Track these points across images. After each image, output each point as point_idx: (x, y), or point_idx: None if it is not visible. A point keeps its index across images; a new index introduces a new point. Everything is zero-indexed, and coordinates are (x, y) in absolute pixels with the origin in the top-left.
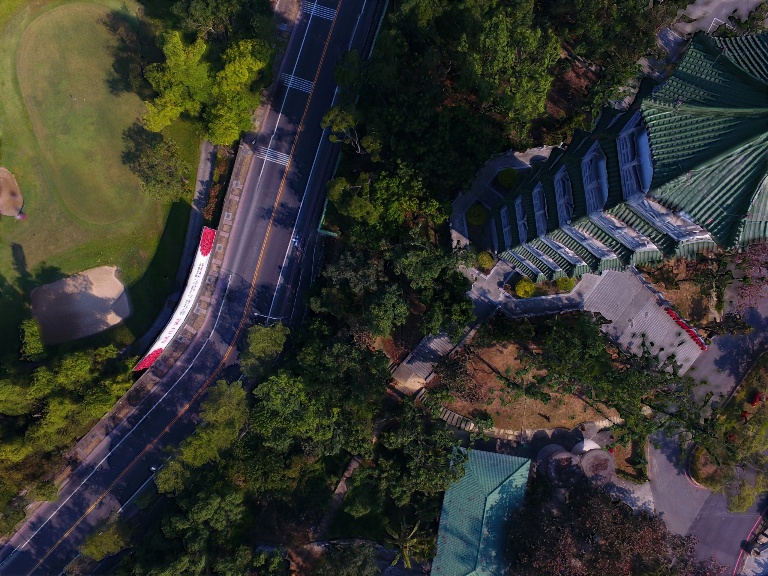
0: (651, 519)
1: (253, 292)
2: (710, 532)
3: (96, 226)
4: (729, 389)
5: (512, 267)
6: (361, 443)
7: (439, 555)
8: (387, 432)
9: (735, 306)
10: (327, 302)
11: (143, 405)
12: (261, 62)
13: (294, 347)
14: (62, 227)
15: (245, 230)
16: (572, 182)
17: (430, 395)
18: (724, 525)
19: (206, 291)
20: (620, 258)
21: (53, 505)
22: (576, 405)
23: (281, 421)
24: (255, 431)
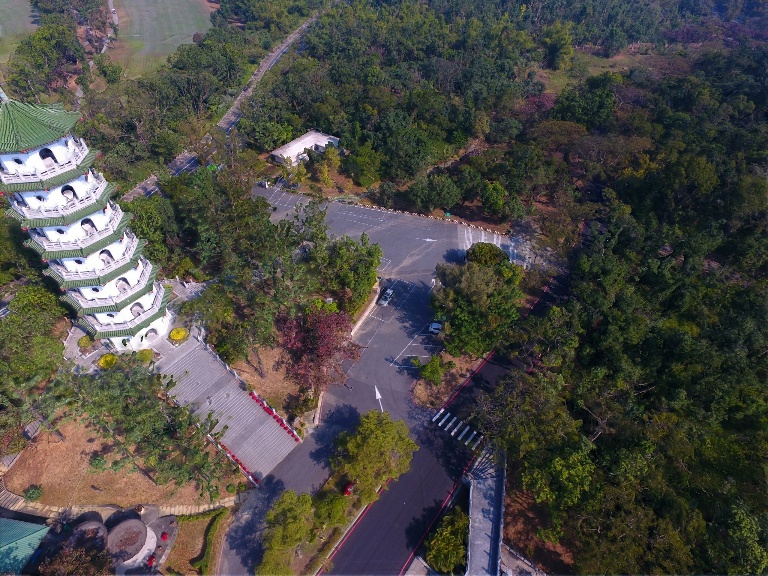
0: None
1: None
2: None
3: None
4: (322, 482)
5: None
6: None
7: None
8: None
9: None
10: None
11: None
12: None
13: None
14: None
15: None
16: None
17: None
18: None
19: None
20: None
21: None
22: (140, 482)
23: None
24: None
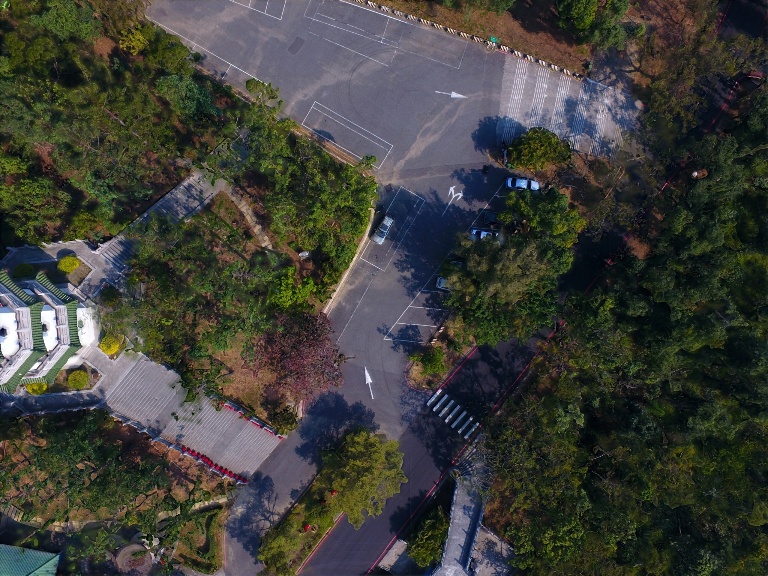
0: None
1: None
2: None
3: None
4: (310, 477)
5: None
6: None
7: None
8: None
9: None
10: None
11: None
12: None
13: None
14: None
15: None
16: None
17: None
18: None
19: None
20: None
21: None
22: None
23: None
24: None
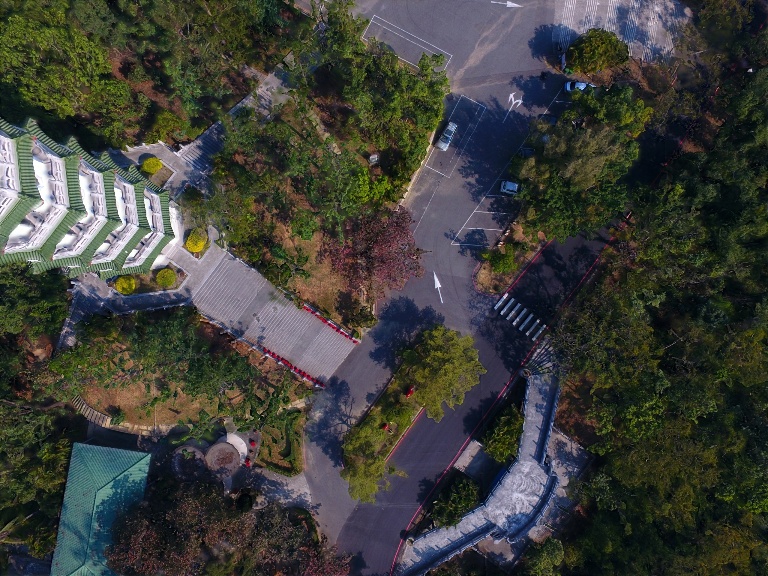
0: (280, 511)
1: None
2: (369, 523)
3: None
4: (385, 381)
5: None
6: None
7: (58, 551)
8: None
9: None
10: None
11: None
12: None
13: None
14: None
15: None
16: None
17: None
18: (383, 515)
19: None
20: None
21: None
22: (213, 400)
23: None
24: None
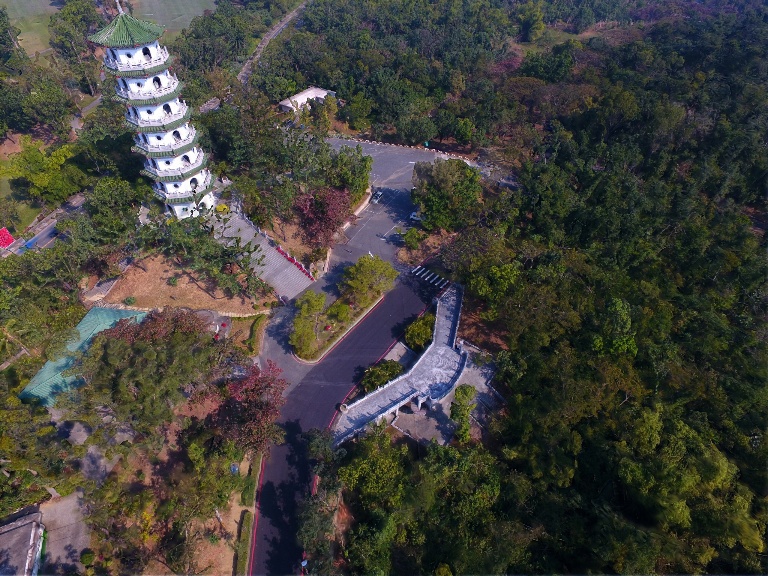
0: None
1: None
2: (308, 396)
3: None
4: (331, 303)
5: None
6: None
7: (41, 372)
8: None
9: None
10: None
11: None
12: (72, 153)
13: None
14: None
15: None
16: None
17: None
18: (322, 391)
19: None
20: None
21: None
22: (203, 297)
23: None
24: None
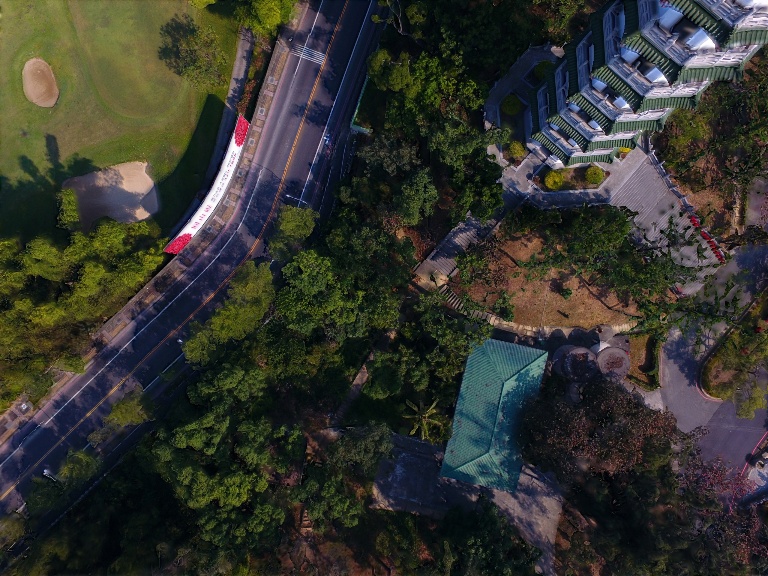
0: None
1: (282, 187)
2: (717, 443)
3: (130, 120)
4: None
5: (542, 160)
6: (388, 309)
7: (454, 438)
8: (408, 322)
9: (757, 219)
10: (357, 191)
11: (169, 292)
12: None
13: (322, 235)
14: (96, 119)
15: (277, 126)
16: (625, 1)
17: (460, 259)
18: (731, 438)
19: (236, 184)
20: (667, 76)
21: (77, 385)
22: (595, 306)
23: (306, 304)
24: (280, 314)
